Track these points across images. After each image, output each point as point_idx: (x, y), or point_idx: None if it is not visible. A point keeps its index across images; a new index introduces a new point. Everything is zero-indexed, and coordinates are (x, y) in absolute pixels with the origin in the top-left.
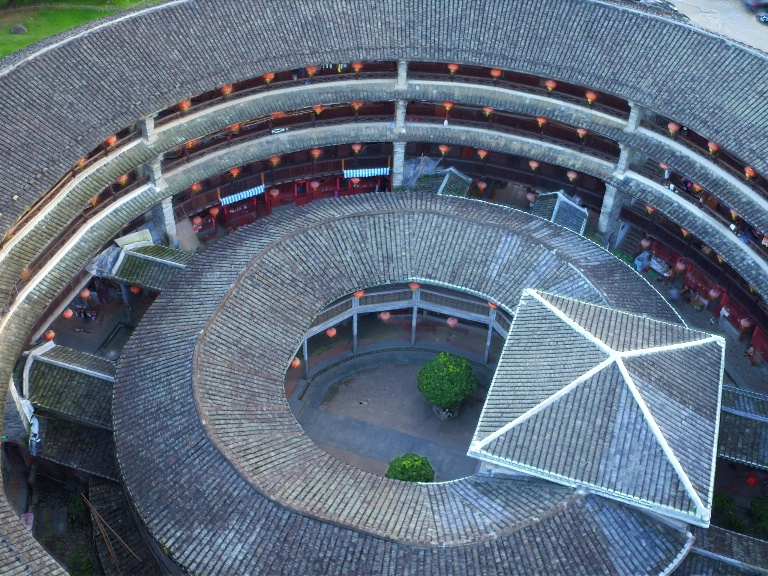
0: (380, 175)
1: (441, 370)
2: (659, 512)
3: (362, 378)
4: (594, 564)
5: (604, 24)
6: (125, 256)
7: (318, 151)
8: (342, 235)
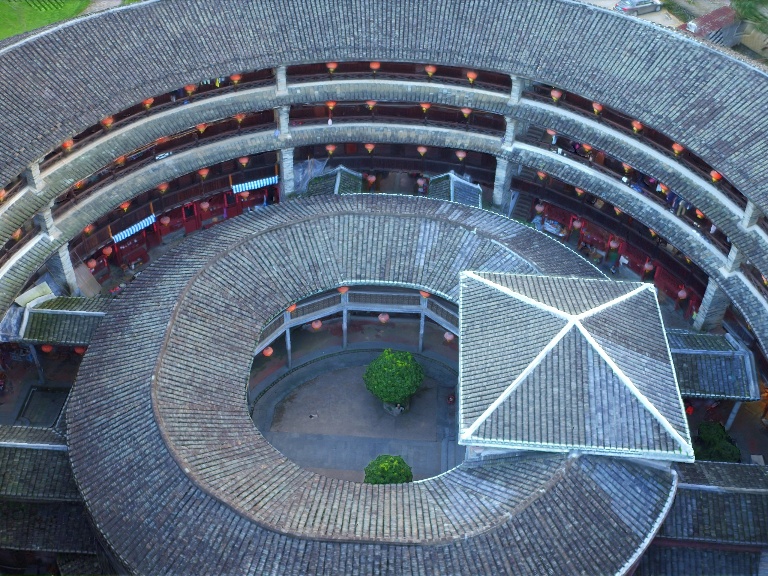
0: (269, 185)
1: (389, 367)
2: (648, 458)
3: (304, 391)
4: (603, 520)
5: (470, 4)
6: (30, 315)
7: (206, 171)
8: (263, 252)
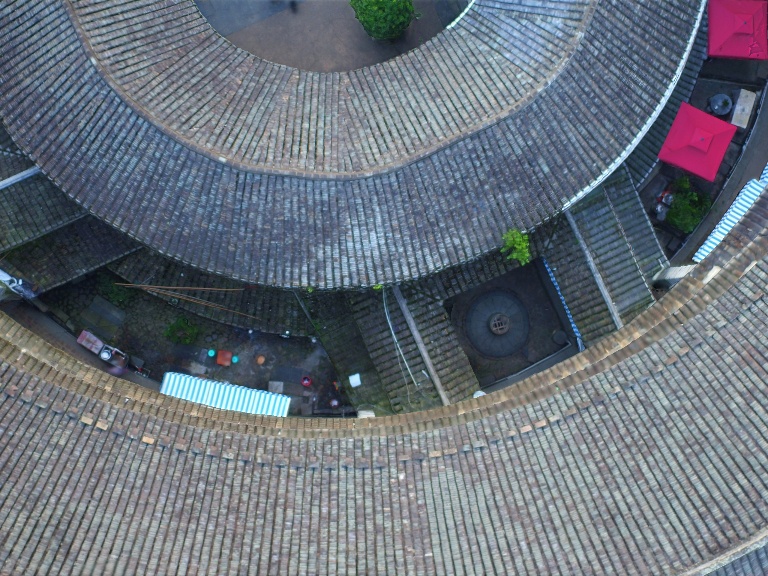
0: None
1: None
2: None
3: None
4: None
5: None
6: None
7: None
8: None
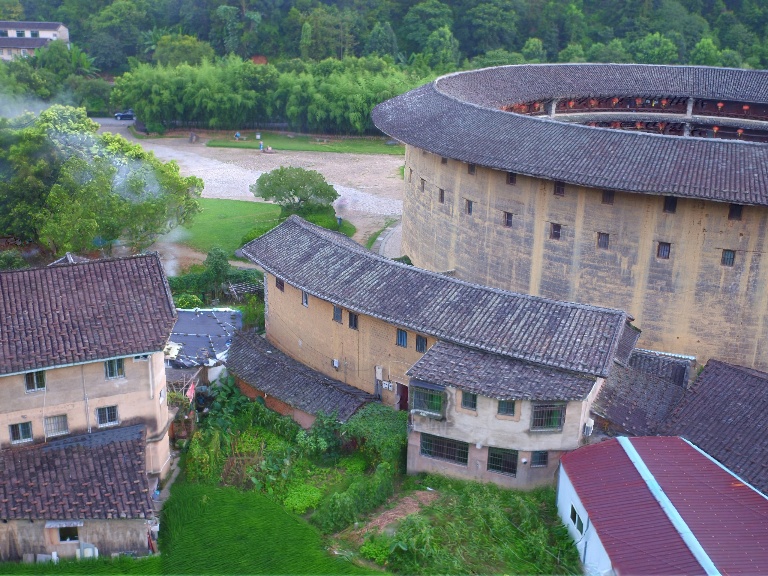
0: None
1: None
2: None
3: None
4: None
5: None
6: None
7: None
8: None
